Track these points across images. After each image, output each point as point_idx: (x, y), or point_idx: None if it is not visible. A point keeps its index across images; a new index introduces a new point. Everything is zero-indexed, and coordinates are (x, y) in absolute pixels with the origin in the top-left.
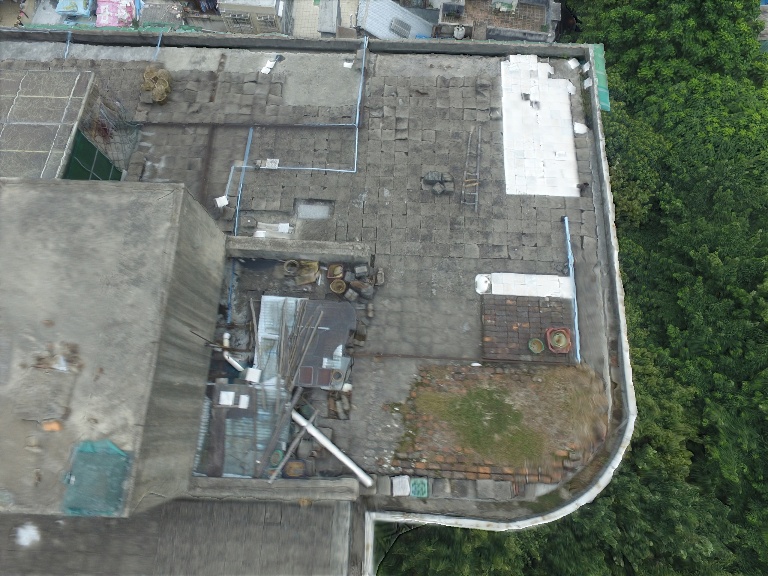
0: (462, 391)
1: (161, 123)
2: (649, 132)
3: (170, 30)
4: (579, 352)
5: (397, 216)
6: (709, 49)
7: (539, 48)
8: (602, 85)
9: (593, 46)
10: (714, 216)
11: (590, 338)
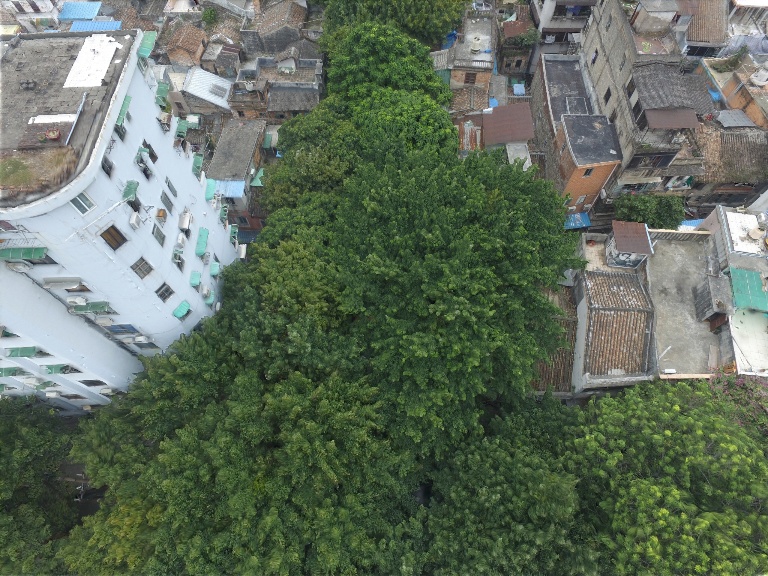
0: (2, 160)
1: None
2: None
3: None
4: (70, 142)
5: (1, 99)
6: (384, 73)
7: (111, 31)
8: (147, 47)
9: None
10: None
11: (79, 137)
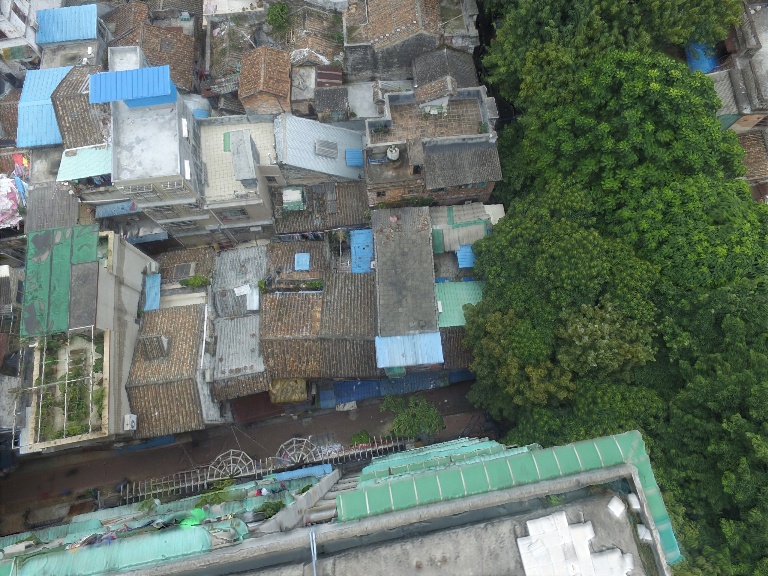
0: None
1: None
2: (633, 258)
3: (13, 571)
4: None
5: None
6: (675, 152)
7: (563, 492)
8: (658, 511)
9: (636, 468)
10: (728, 348)
11: None
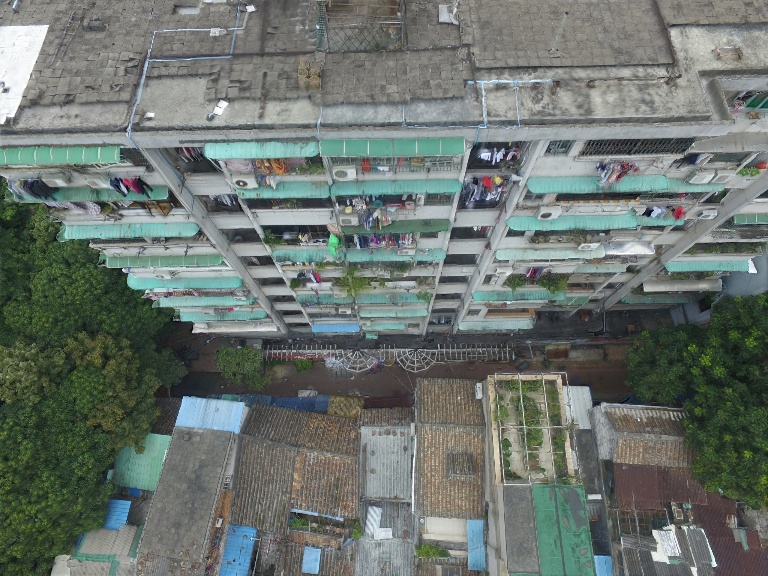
0: None
1: (301, 51)
2: None
3: (319, 149)
4: None
5: (130, 8)
6: None
7: None
8: None
9: None
10: None
11: None
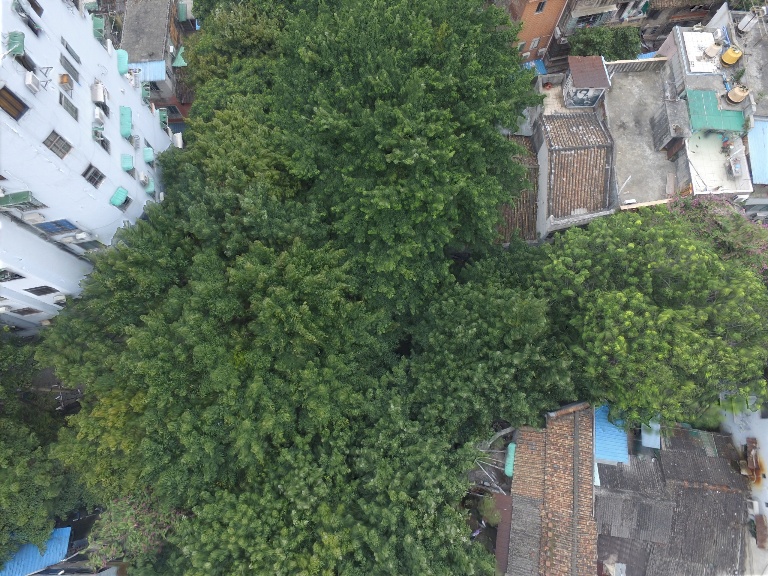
0: None
1: None
2: None
3: None
4: None
5: None
6: None
7: None
8: None
9: None
10: None
11: None
